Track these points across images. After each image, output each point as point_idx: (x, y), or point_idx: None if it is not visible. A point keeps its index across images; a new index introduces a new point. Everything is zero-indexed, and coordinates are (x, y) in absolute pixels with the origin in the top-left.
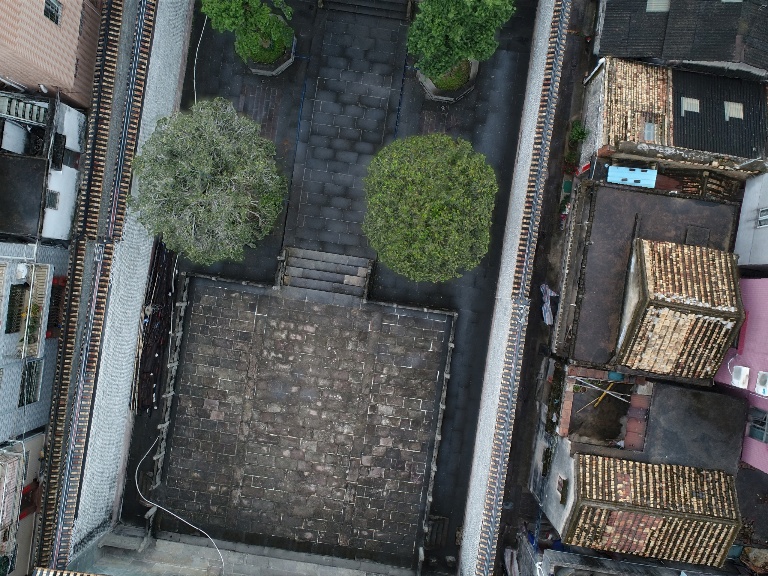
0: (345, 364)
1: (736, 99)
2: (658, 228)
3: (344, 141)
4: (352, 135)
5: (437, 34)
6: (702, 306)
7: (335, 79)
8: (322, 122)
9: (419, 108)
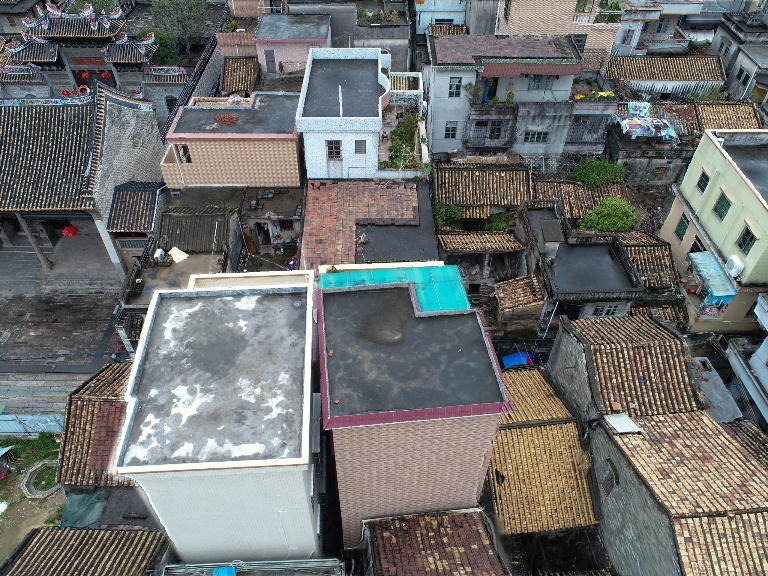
0: None
1: None
2: None
3: None
4: None
5: None
6: None
7: None
8: None
9: None
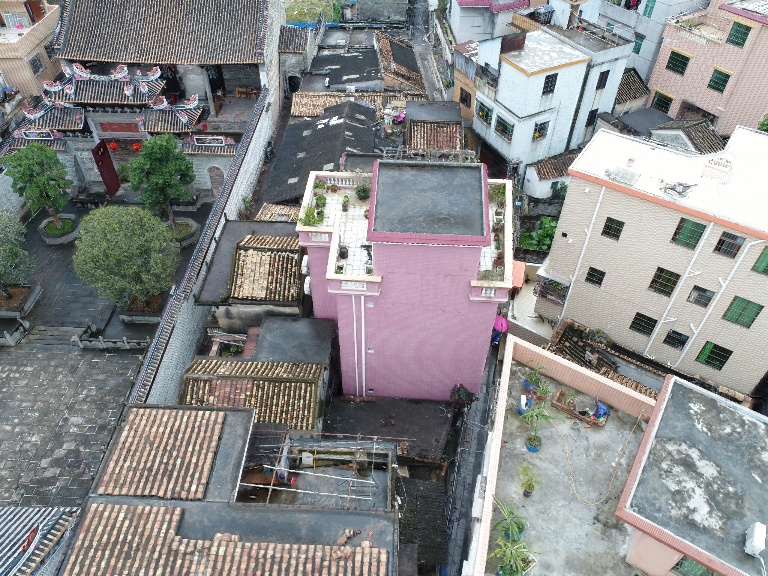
0: (51, 390)
1: None
2: None
3: None
4: None
5: (136, 166)
6: None
7: None
8: None
9: None
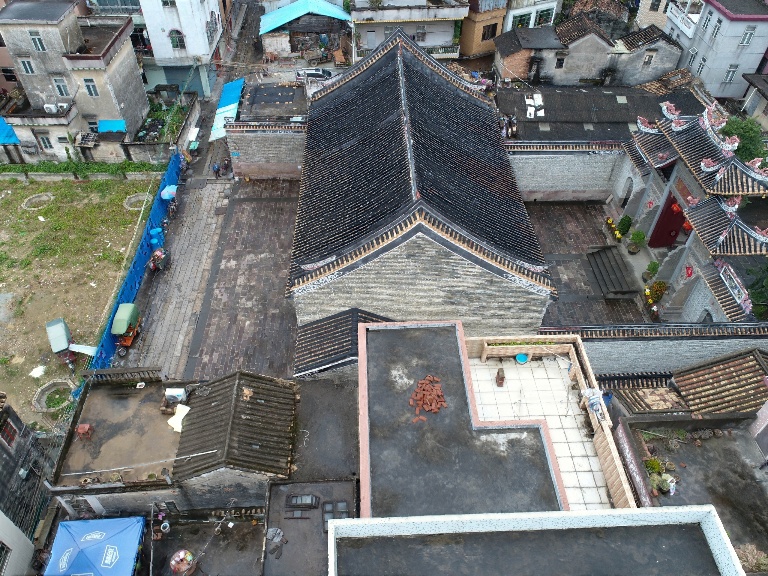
0: None
1: None
2: None
3: None
4: None
5: None
6: None
7: None
8: None
9: None
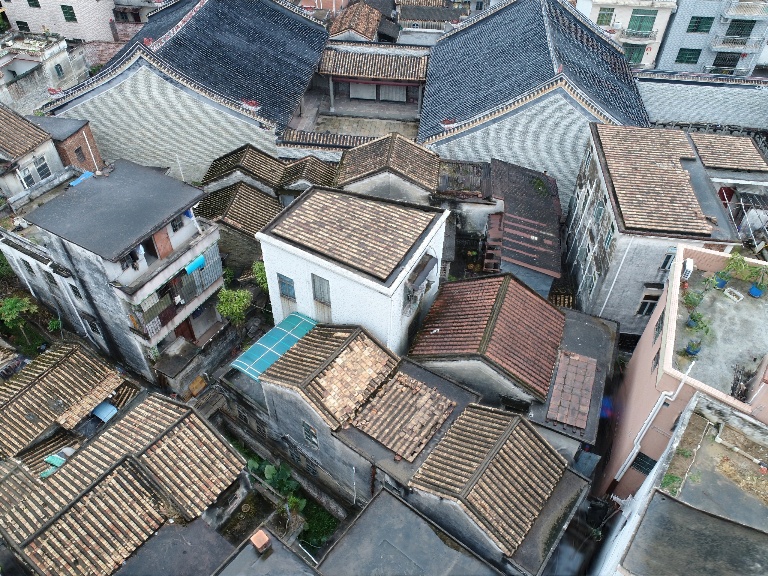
0: None
1: None
2: None
3: None
4: None
5: None
6: None
7: None
8: None
9: None
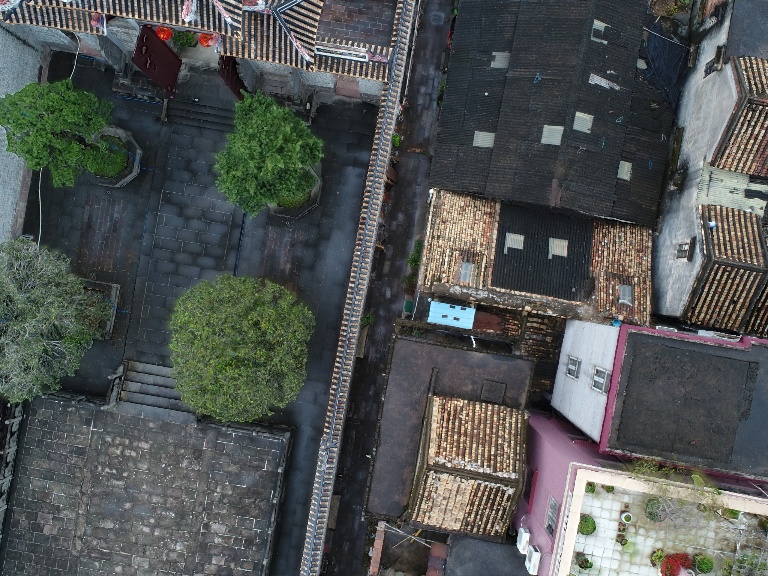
0: (179, 481)
1: (562, 235)
2: (455, 382)
3: (187, 255)
4: (195, 249)
5: (232, 186)
6: (482, 472)
7: (179, 193)
8: (165, 236)
9: (264, 223)
